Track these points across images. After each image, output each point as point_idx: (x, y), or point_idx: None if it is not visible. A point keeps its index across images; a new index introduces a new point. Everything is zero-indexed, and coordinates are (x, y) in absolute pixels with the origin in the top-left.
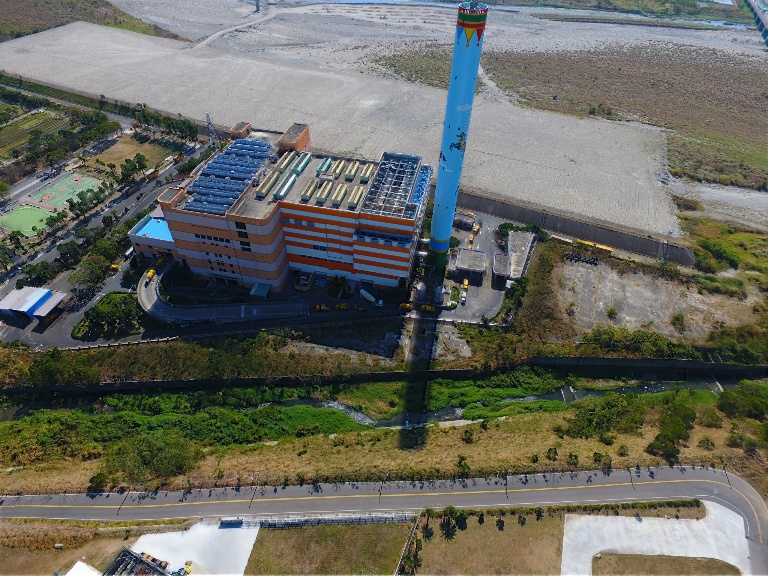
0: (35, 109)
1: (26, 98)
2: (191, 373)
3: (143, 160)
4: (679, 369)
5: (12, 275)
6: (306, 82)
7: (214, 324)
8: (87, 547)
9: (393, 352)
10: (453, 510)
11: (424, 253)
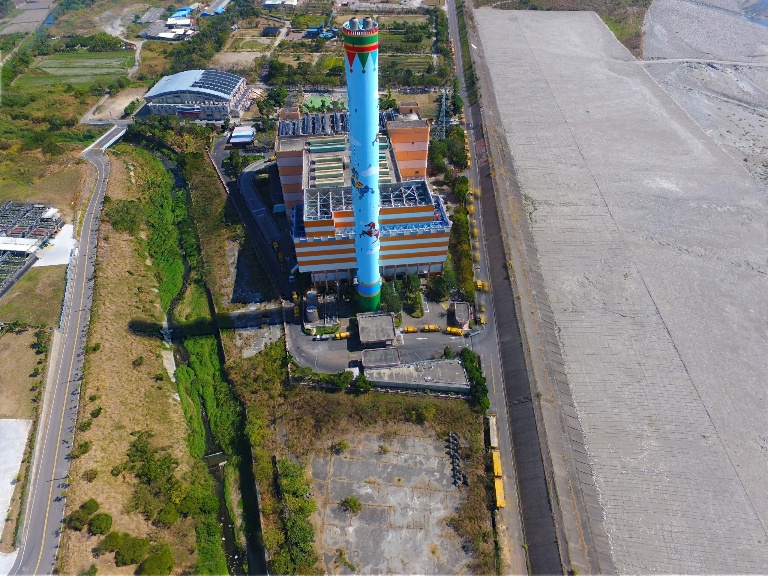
0: (434, 53)
1: None
2: None
3: (393, 106)
4: None
5: None
6: (650, 133)
7: (245, 203)
8: (70, 211)
9: (238, 302)
10: (40, 336)
11: (355, 282)
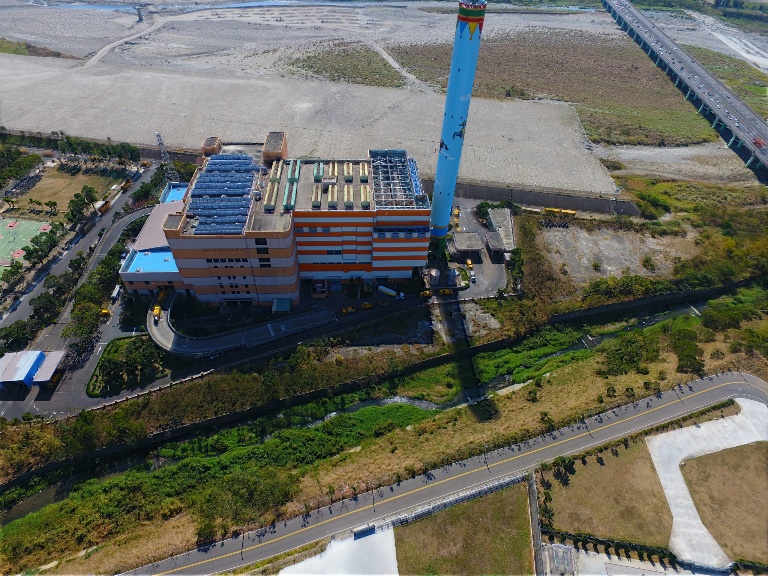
0: None
1: None
2: None
3: (92, 192)
4: (662, 302)
5: None
6: (230, 91)
7: (245, 349)
8: None
9: (431, 338)
10: (564, 459)
11: None
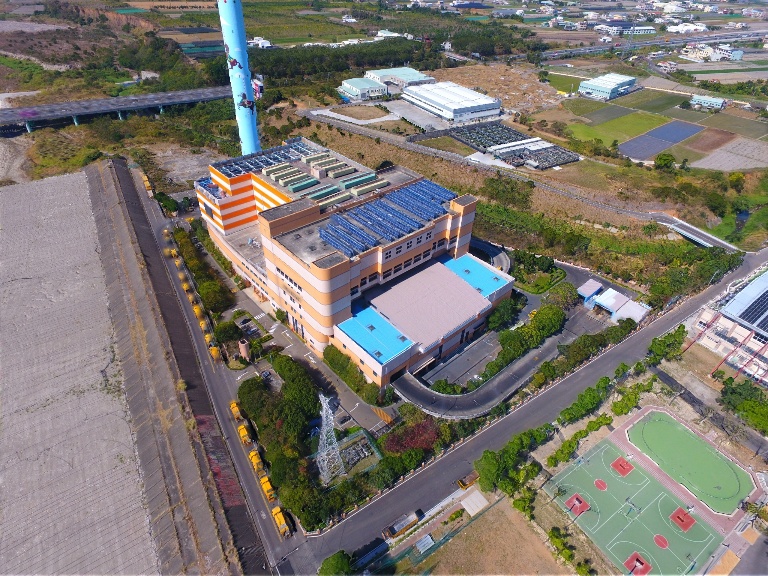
0: None
1: None
2: None
3: None
4: None
5: None
6: None
7: None
8: None
9: None
10: None
11: None
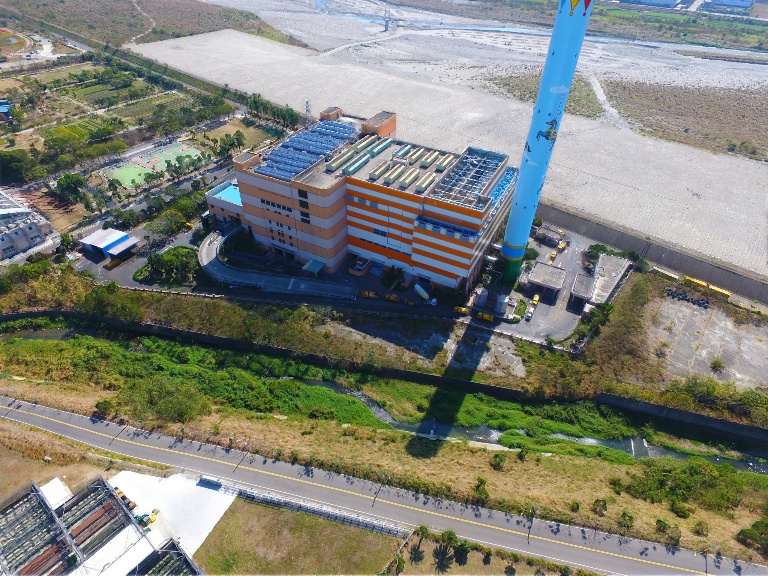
0: (169, 90)
1: (165, 81)
2: (224, 330)
3: (242, 137)
4: None
5: (104, 218)
6: (414, 92)
7: (261, 291)
8: (71, 467)
9: (435, 354)
10: (452, 536)
11: (493, 258)
